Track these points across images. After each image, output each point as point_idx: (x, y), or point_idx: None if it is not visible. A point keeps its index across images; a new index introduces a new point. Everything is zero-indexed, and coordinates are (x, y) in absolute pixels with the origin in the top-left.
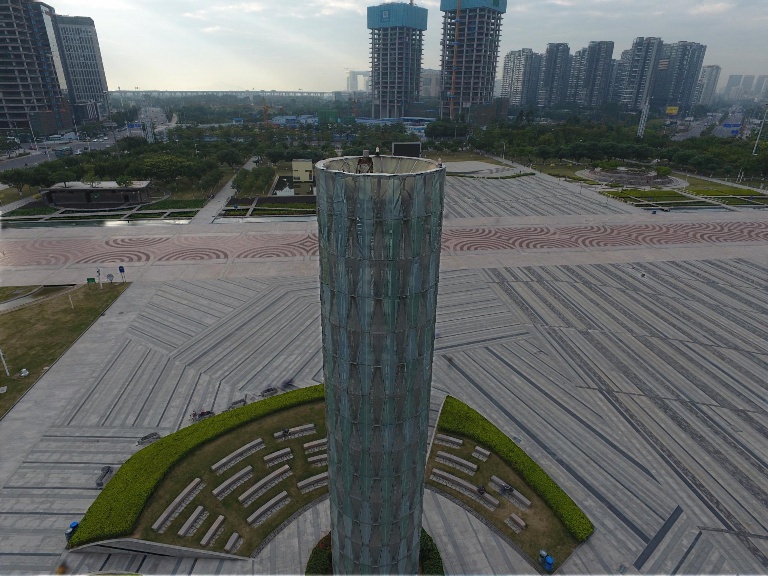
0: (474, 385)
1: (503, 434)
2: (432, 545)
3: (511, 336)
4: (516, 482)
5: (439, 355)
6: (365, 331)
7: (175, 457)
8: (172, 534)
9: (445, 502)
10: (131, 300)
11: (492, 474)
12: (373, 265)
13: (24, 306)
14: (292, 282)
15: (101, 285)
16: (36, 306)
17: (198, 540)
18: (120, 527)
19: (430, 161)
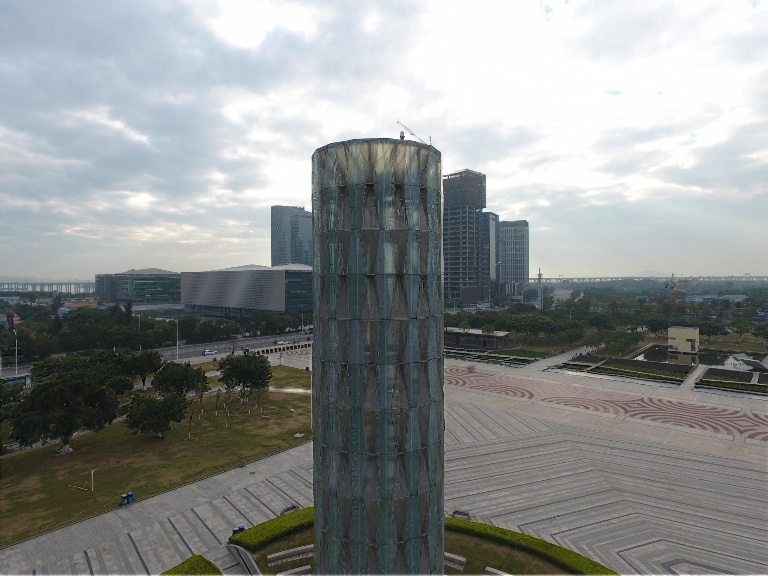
0: None
1: None
2: None
3: None
4: None
5: None
6: (317, 315)
7: None
8: (274, 572)
9: None
10: None
11: None
12: (320, 238)
13: None
14: (581, 433)
15: None
16: None
17: None
18: (251, 540)
19: None
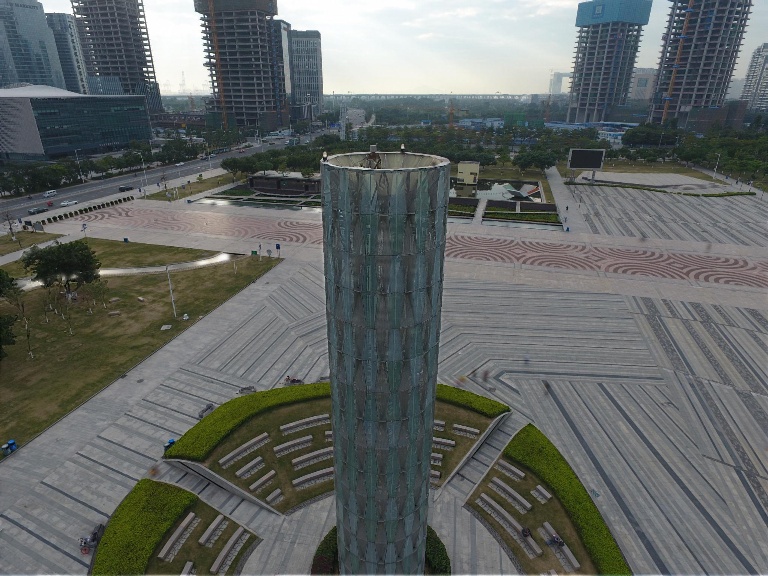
0: (567, 420)
1: (578, 482)
2: (446, 567)
3: (637, 378)
4: (571, 538)
5: (539, 379)
6: (348, 322)
7: (255, 410)
8: (231, 472)
9: (482, 530)
10: (279, 274)
11: (546, 520)
12: (353, 258)
13: (205, 266)
14: None
15: (261, 258)
16: (212, 267)
17: (249, 484)
18: (196, 453)
19: (442, 160)
